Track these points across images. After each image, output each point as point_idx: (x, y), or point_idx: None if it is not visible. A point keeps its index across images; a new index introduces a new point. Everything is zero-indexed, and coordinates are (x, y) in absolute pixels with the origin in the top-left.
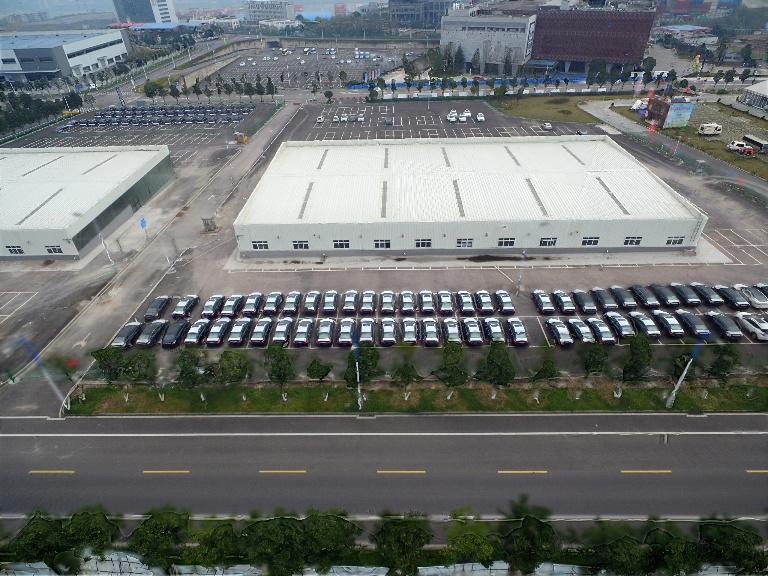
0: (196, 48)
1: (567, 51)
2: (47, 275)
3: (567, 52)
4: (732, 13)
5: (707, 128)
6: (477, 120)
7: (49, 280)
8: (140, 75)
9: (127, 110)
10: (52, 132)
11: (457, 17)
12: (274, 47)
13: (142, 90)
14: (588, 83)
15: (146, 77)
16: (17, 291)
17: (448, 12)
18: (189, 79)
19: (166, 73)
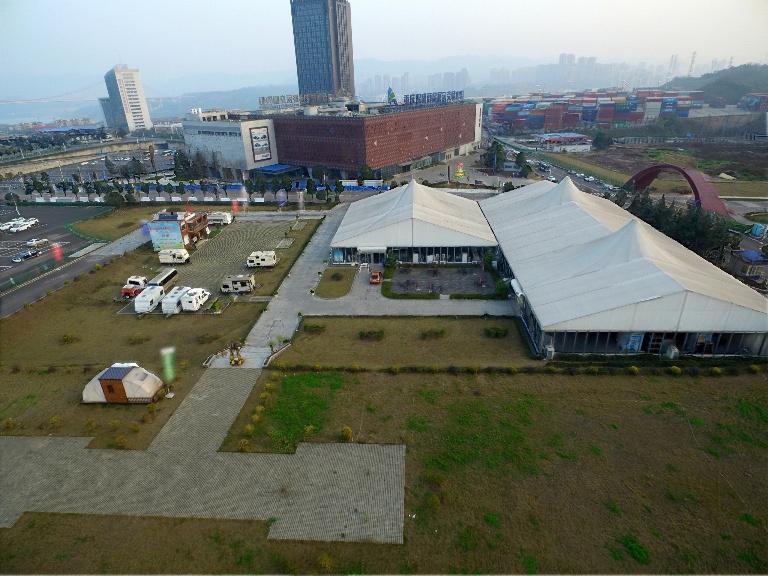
0: None
1: (304, 157)
2: None
3: (305, 158)
4: (658, 122)
5: (161, 255)
6: None
7: None
8: None
9: None
10: None
11: (191, 121)
12: None
13: None
14: (247, 191)
15: None
16: None
17: None
18: None
19: None
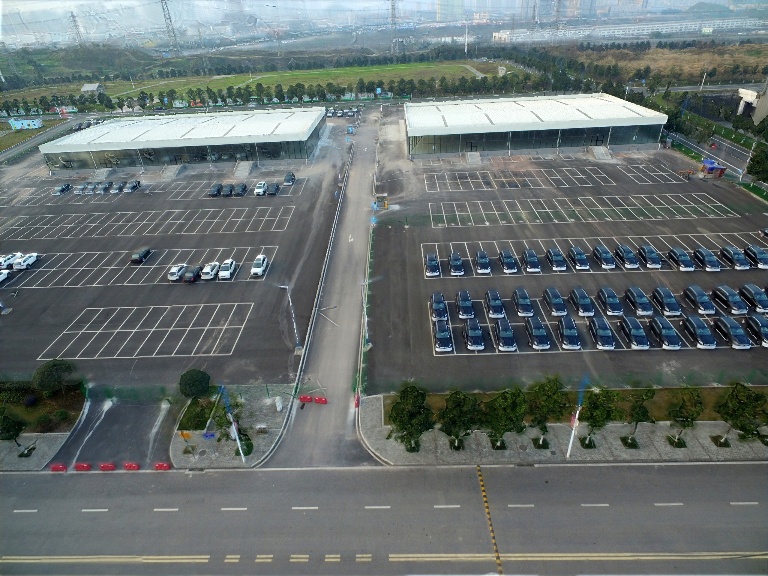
0: None
1: None
2: None
3: None
4: None
5: None
6: None
7: None
8: None
9: None
10: None
11: None
12: None
13: None
14: None
15: None
16: None
17: None
18: None
19: None
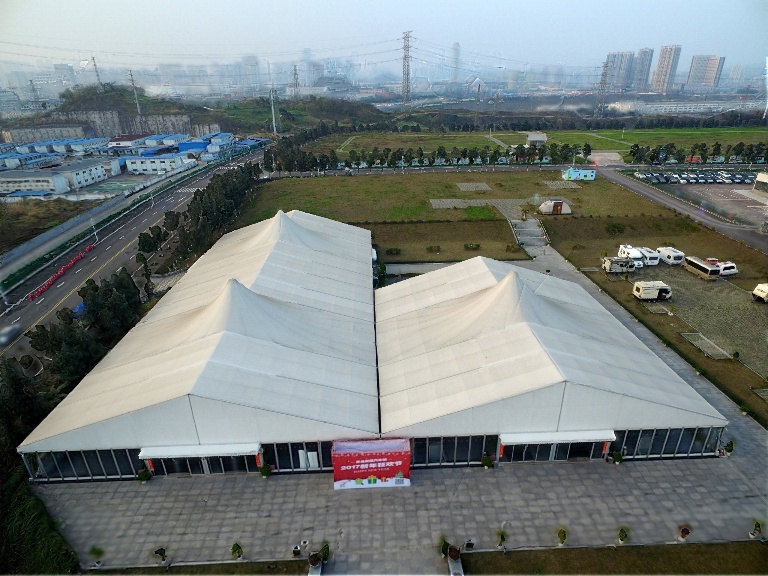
0: None
1: None
2: None
3: None
4: None
5: None
6: None
7: None
8: None
9: None
10: None
11: None
12: None
13: None
14: None
15: None
16: None
17: None
18: None
19: None
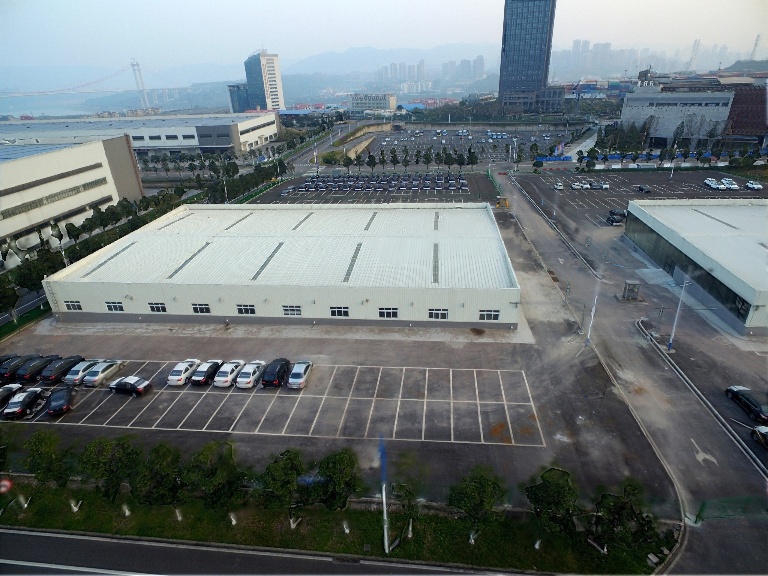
0: (333, 130)
1: (767, 126)
2: (501, 348)
3: (767, 127)
4: None
5: None
6: (752, 188)
7: (514, 355)
8: (304, 150)
9: (333, 177)
10: (277, 196)
11: (644, 93)
12: (398, 130)
13: (321, 162)
14: None
15: (316, 151)
16: (491, 368)
17: (634, 89)
18: (350, 154)
19: (327, 149)
